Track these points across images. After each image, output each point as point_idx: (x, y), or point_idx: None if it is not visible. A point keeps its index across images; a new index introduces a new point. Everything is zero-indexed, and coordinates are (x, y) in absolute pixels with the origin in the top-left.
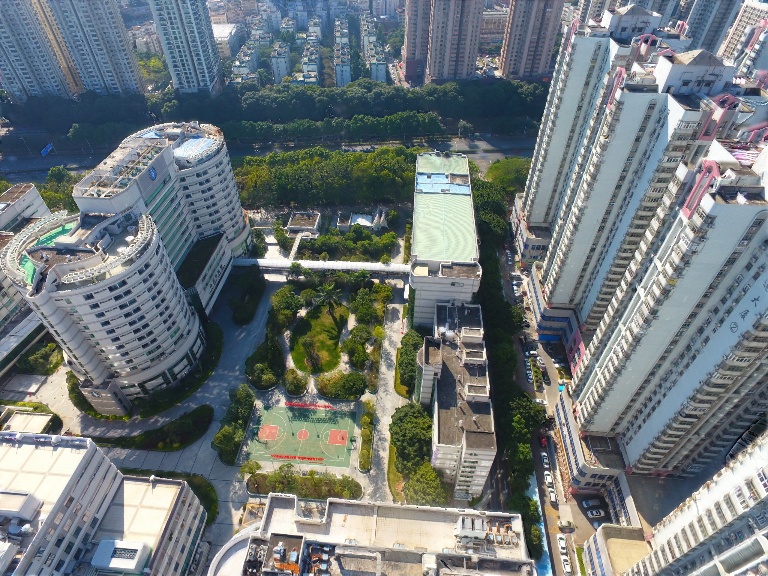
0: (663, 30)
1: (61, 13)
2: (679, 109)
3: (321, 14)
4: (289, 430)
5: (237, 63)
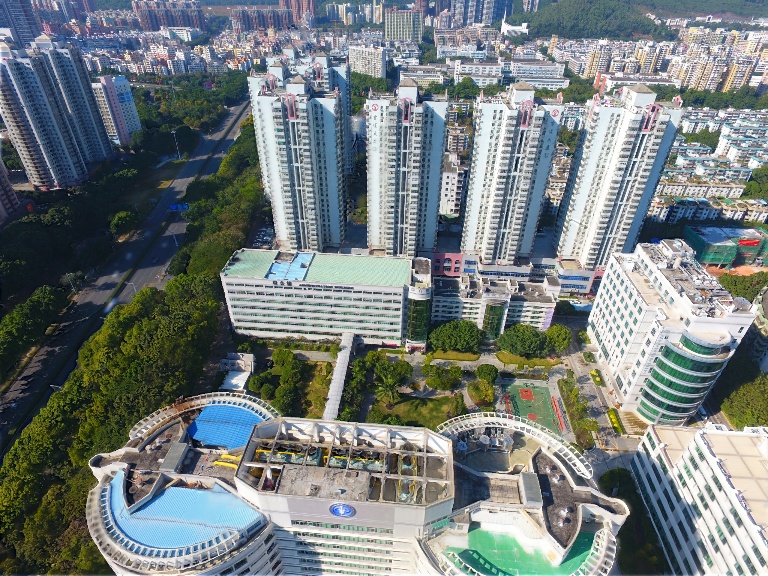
0: None
1: None
2: (443, 103)
3: None
4: None
5: None
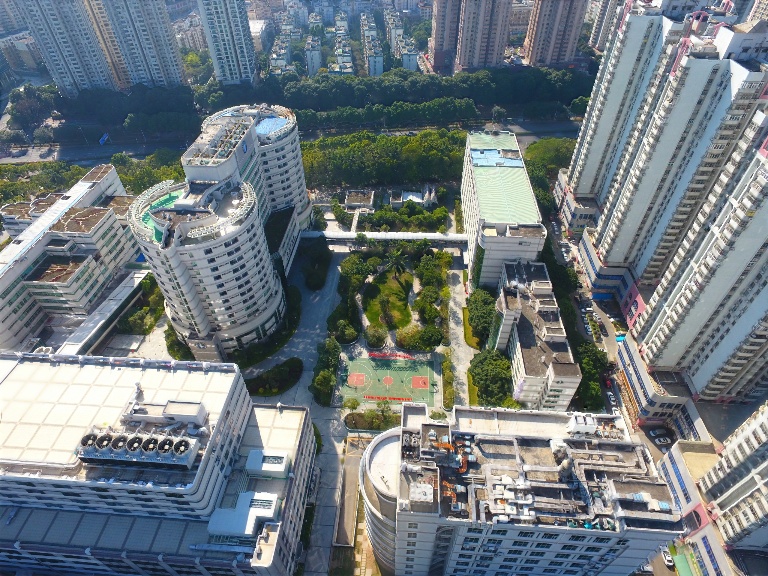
0: (710, 8)
1: (113, 9)
2: (743, 71)
3: (346, 9)
4: (375, 377)
5: (274, 56)
